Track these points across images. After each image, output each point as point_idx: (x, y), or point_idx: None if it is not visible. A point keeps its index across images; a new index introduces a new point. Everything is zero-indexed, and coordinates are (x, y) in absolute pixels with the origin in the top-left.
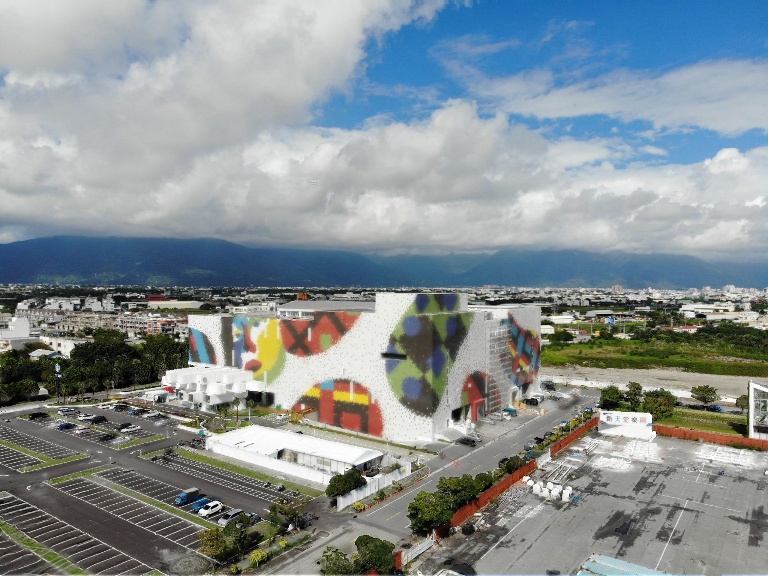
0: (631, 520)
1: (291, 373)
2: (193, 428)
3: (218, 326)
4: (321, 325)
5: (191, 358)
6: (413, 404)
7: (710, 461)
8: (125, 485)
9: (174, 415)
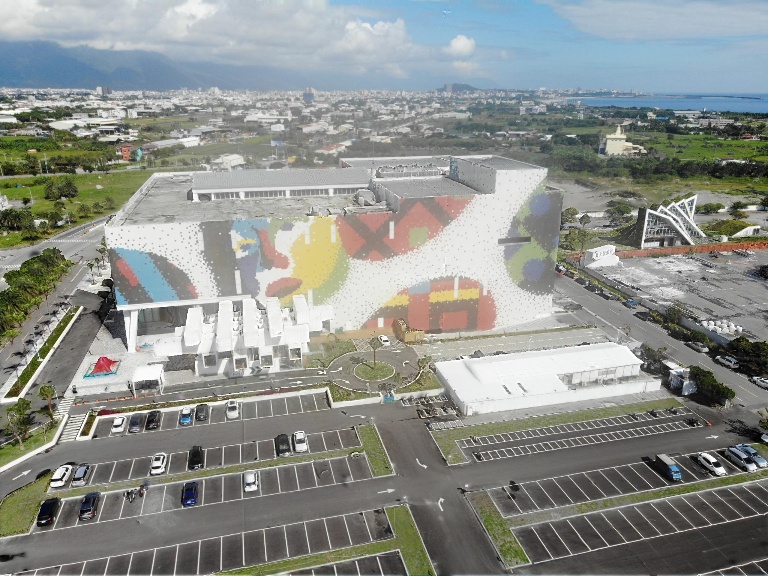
0: None
1: (360, 284)
2: (368, 399)
3: (194, 238)
4: (412, 216)
5: (124, 299)
6: (534, 285)
7: (679, 272)
8: (578, 500)
9: (271, 394)
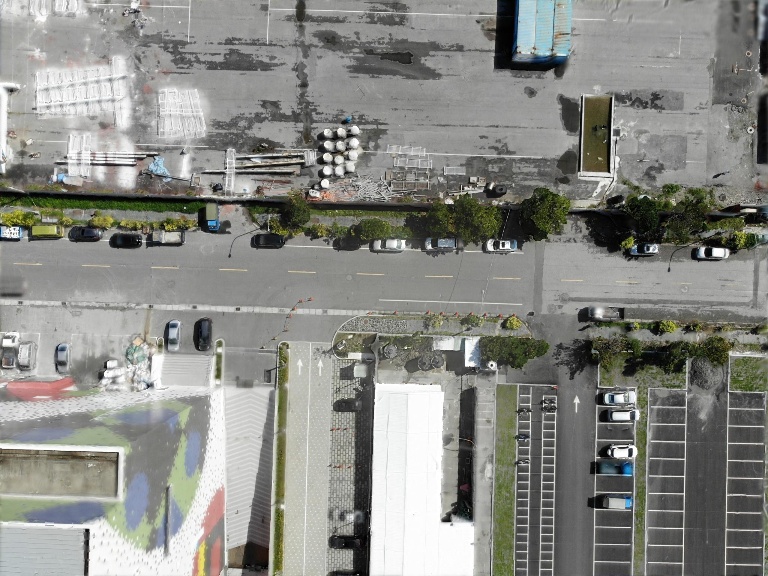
0: (372, 55)
1: None
2: None
3: None
4: None
5: None
6: None
7: None
8: None
9: None
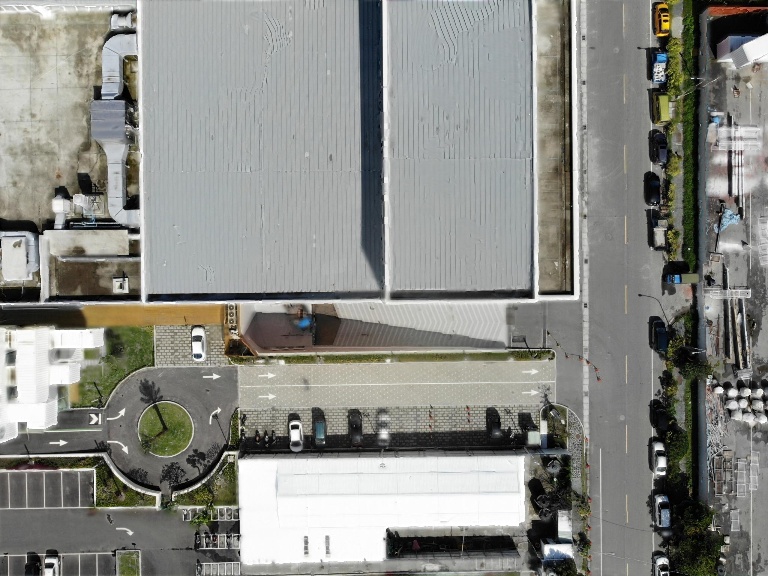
0: None
1: None
2: None
3: None
4: None
5: None
6: None
7: None
8: None
9: None
